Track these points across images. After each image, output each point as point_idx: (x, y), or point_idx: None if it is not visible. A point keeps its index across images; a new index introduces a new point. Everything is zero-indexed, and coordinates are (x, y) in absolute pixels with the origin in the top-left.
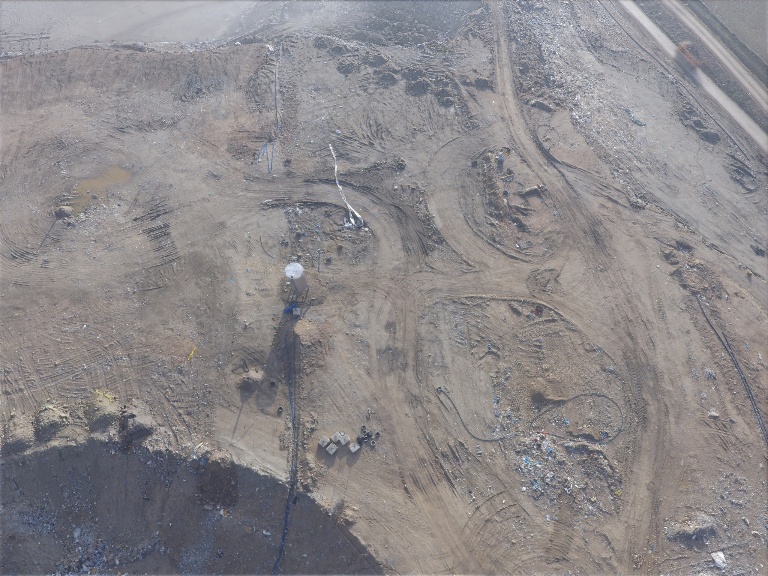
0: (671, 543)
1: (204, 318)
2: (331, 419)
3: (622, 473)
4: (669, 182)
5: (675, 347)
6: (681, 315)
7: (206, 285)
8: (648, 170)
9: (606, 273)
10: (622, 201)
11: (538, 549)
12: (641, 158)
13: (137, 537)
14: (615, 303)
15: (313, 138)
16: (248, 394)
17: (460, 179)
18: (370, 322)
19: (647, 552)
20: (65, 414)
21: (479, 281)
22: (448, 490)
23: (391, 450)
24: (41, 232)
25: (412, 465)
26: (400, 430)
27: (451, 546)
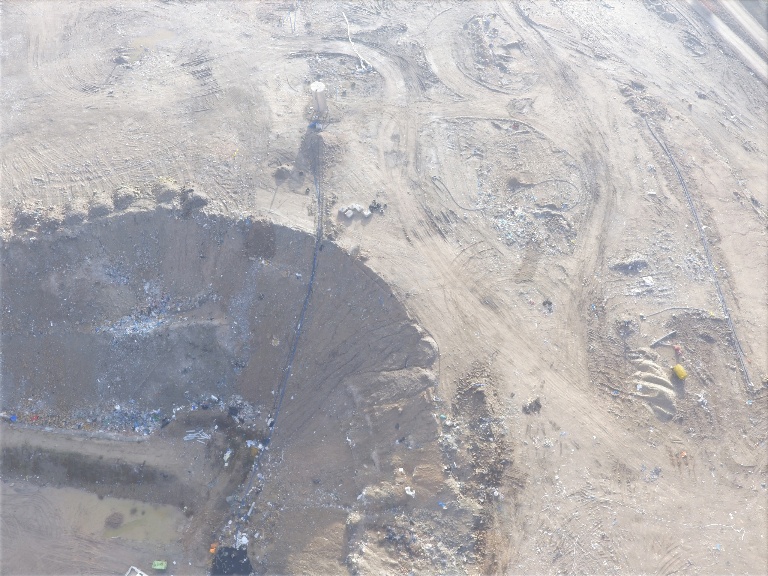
0: (612, 271)
1: (244, 130)
2: (348, 196)
3: (577, 229)
4: (630, 47)
5: (625, 150)
6: (631, 129)
7: (244, 109)
8: (613, 39)
9: (572, 101)
10: (588, 53)
11: (509, 275)
12: (608, 30)
13: (195, 289)
14: (578, 121)
15: (329, 8)
16: (282, 180)
17: (453, 38)
18: (379, 134)
19: (593, 277)
20: (137, 191)
21: (468, 107)
22: (441, 239)
23: (396, 215)
24: (105, 73)
25: (413, 224)
26: (403, 202)
27: (442, 272)
